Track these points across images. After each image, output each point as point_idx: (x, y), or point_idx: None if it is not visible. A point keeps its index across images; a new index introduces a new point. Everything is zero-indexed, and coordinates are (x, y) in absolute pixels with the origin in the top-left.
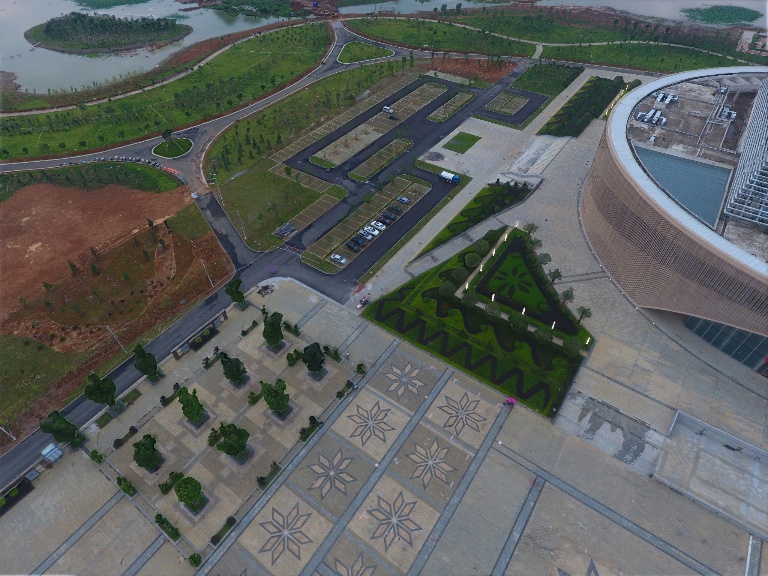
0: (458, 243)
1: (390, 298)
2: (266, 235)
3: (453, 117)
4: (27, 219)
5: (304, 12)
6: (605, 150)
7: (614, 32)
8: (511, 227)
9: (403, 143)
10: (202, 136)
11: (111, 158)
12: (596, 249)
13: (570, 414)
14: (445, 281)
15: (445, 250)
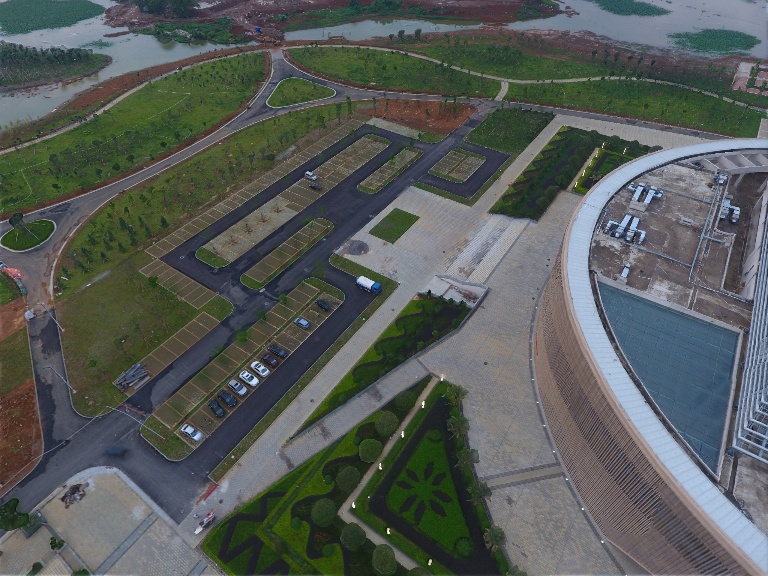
0: (361, 404)
1: (246, 515)
2: (105, 385)
3: (389, 186)
4: None
5: (244, 38)
6: (559, 287)
7: (592, 65)
8: (436, 377)
9: (320, 226)
10: (71, 216)
11: None
12: (549, 422)
13: None
14: (328, 486)
15: (342, 416)
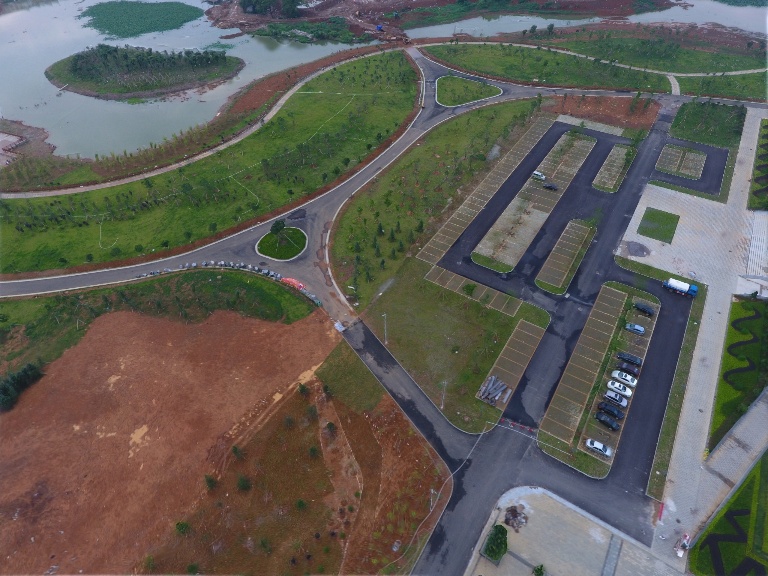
0: (763, 413)
1: (723, 535)
2: (469, 400)
3: (625, 184)
4: (116, 379)
5: (368, 37)
6: None
7: (749, 57)
8: None
9: (583, 228)
10: (314, 223)
11: (205, 263)
12: None
13: None
14: None
15: (750, 427)
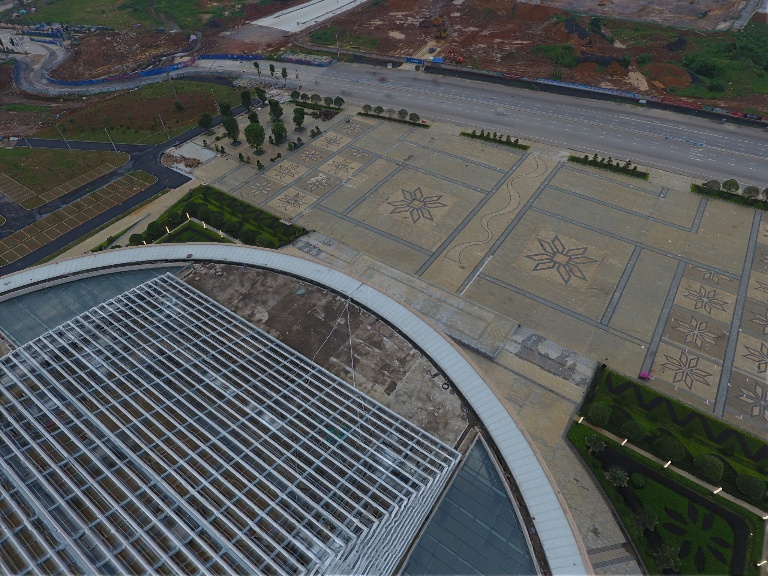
0: None
1: None
2: None
3: None
4: None
5: None
6: None
7: None
8: None
9: None
10: None
11: None
12: None
13: (584, 368)
14: None
15: None
